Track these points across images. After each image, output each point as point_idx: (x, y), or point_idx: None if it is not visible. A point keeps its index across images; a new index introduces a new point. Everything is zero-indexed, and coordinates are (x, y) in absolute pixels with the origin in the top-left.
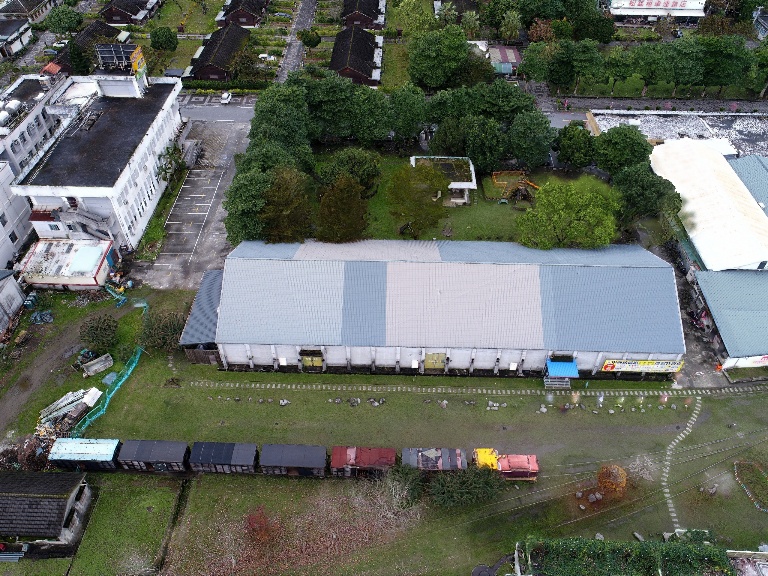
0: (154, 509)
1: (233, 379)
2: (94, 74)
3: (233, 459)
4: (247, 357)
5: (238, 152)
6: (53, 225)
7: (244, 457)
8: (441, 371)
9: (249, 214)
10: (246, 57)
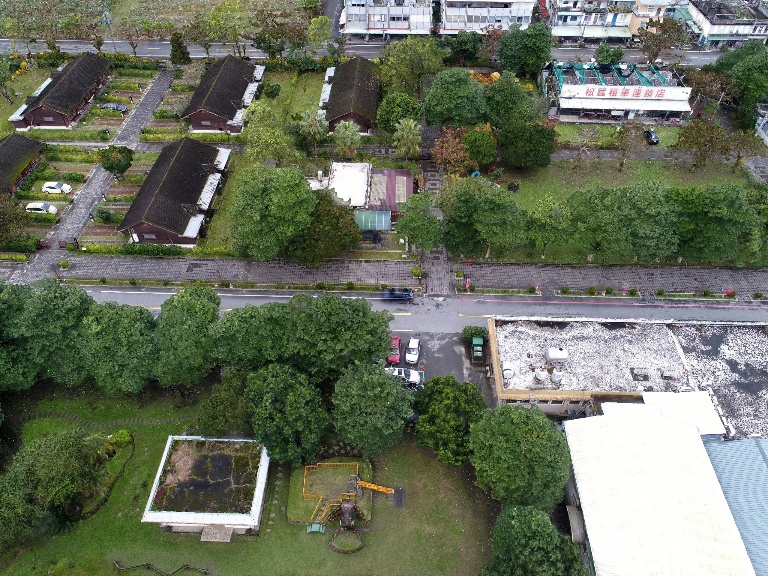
0: None
1: None
2: None
3: None
4: None
5: None
6: None
7: None
8: None
9: None
10: None
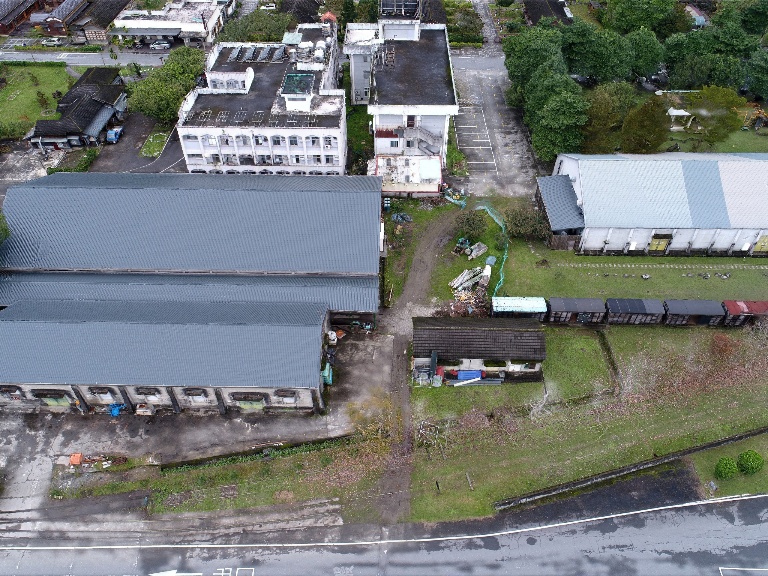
0: (587, 350)
1: (591, 261)
2: (381, 19)
3: (647, 309)
4: (603, 242)
5: (485, 93)
6: (394, 142)
7: (655, 308)
8: (766, 253)
9: (569, 129)
10: (466, 12)
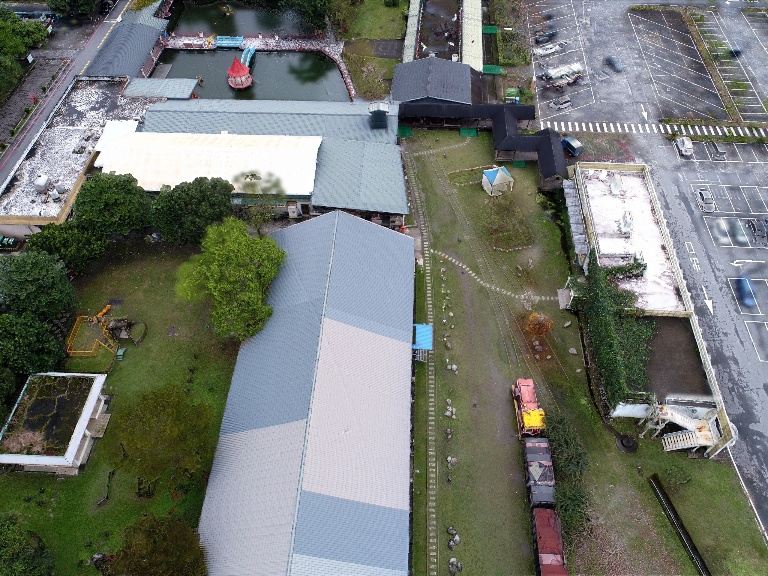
0: None
1: None
2: None
3: None
4: None
5: None
6: None
7: None
8: None
9: None
10: None
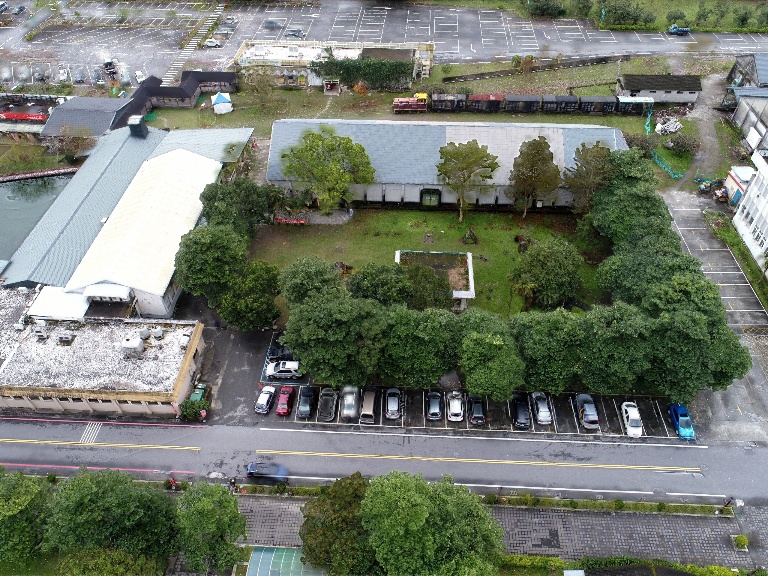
0: None
1: None
2: None
3: None
4: None
5: None
6: None
7: (548, 96)
8: None
9: None
10: None
